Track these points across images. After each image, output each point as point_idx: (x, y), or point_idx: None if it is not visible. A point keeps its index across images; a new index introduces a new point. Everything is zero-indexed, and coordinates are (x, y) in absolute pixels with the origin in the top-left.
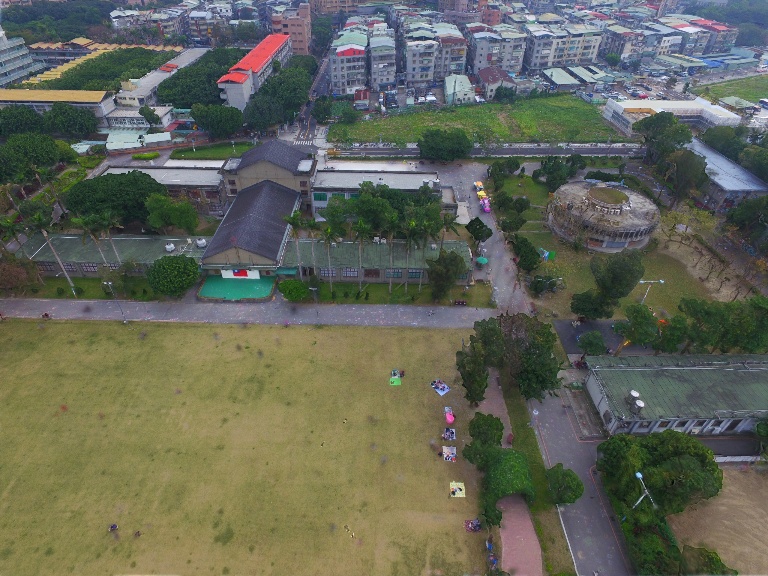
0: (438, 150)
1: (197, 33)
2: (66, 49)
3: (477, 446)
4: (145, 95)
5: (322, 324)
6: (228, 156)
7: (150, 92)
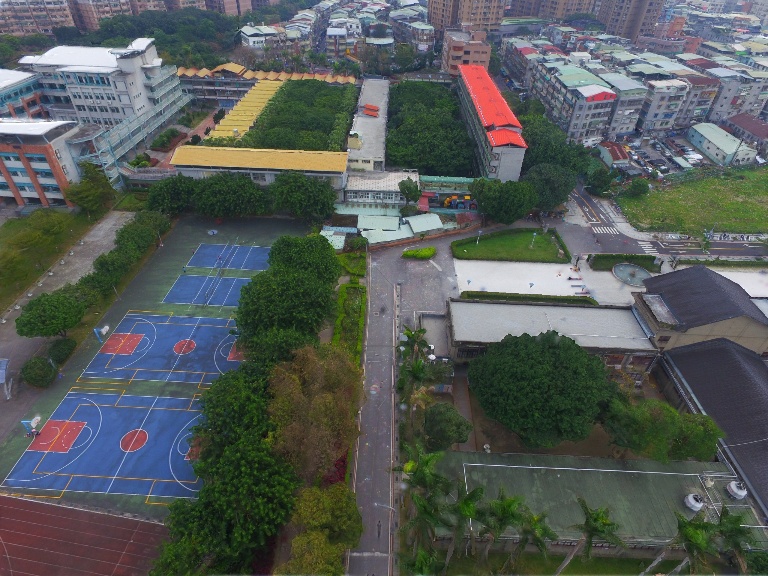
0: None
1: (334, 54)
2: (216, 77)
3: None
4: (383, 157)
5: None
6: (529, 254)
7: (384, 151)
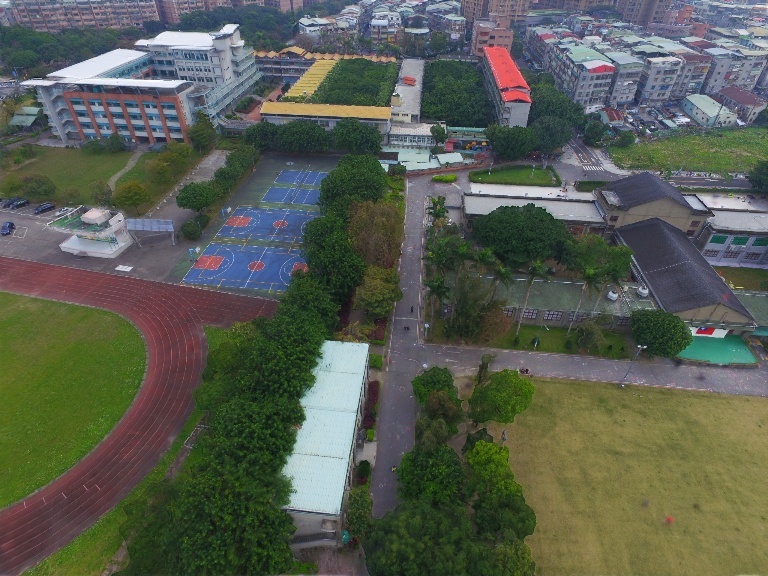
0: None
1: None
2: (283, 58)
3: None
4: (419, 112)
5: None
6: (529, 181)
7: (419, 108)
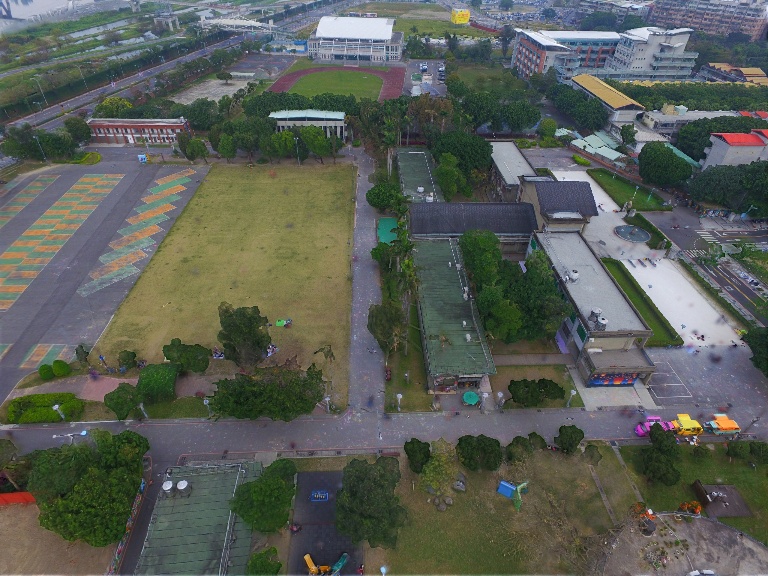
0: (765, 344)
1: None
2: (731, 74)
3: (172, 339)
4: (663, 121)
5: (353, 280)
6: (621, 196)
7: (674, 121)
